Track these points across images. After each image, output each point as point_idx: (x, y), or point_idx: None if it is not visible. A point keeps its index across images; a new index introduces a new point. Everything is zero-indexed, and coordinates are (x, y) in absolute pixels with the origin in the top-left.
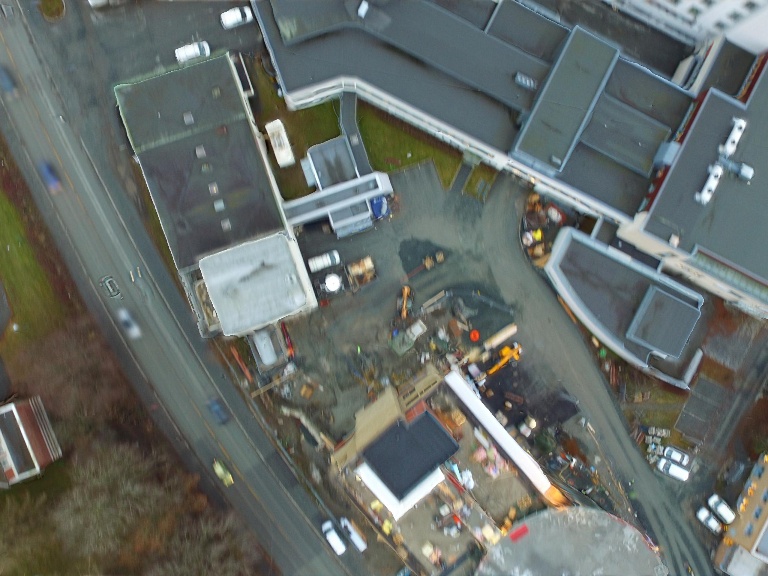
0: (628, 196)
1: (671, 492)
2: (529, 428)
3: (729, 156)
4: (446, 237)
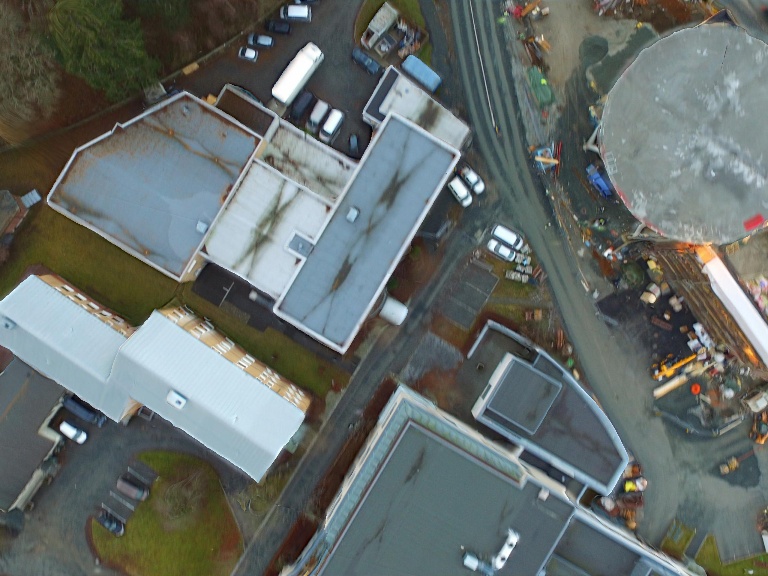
0: (567, 533)
1: (508, 212)
2: (655, 294)
3: None
4: (715, 488)
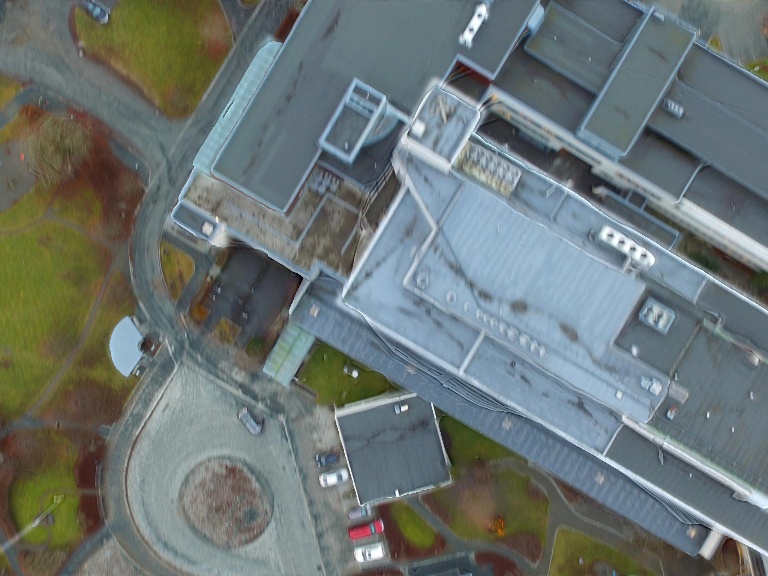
0: None
1: None
2: None
3: (482, 4)
4: None
